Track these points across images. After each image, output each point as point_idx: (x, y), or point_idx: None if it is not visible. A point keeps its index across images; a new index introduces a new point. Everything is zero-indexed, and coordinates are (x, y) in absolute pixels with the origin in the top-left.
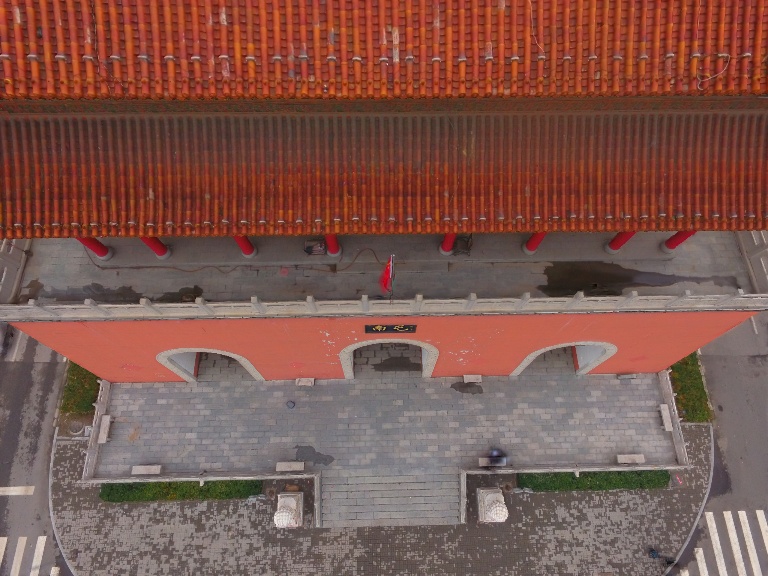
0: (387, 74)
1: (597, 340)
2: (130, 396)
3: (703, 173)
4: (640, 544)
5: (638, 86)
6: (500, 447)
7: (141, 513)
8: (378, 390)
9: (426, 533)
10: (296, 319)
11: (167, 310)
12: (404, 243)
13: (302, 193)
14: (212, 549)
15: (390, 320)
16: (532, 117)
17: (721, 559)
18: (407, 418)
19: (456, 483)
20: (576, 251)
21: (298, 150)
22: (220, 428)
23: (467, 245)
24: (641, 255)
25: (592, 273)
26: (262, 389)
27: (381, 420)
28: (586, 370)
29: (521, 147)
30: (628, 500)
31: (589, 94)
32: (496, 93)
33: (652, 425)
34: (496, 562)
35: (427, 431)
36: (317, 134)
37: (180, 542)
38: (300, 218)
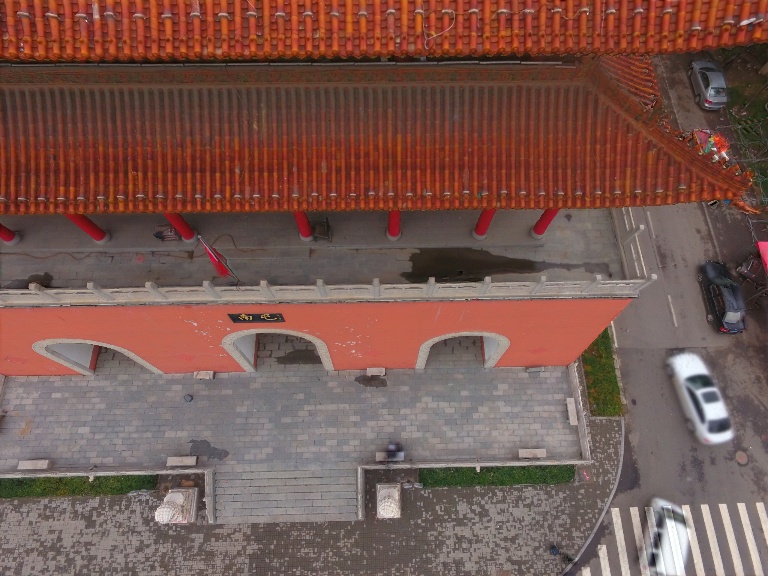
0: (88, 32)
1: (482, 330)
2: (24, 389)
3: (510, 148)
4: (542, 541)
5: (359, 45)
6: (400, 441)
7: (31, 509)
8: (279, 383)
9: (322, 529)
10: (150, 307)
11: (8, 297)
12: (265, 229)
13: (84, 169)
14: (101, 546)
15: (250, 308)
16: (326, 89)
17: (624, 556)
18: (307, 412)
19: (354, 478)
20: (442, 237)
21: (78, 123)
22: (114, 422)
23: (327, 230)
24: (509, 241)
25: (459, 260)
26: (160, 382)
27: (280, 414)
28: (491, 363)
29: (315, 120)
30: (532, 496)
31: (307, 53)
32: (206, 52)
33: (558, 419)
34: (392, 559)
35: (327, 425)
36: (98, 107)
37: (68, 539)
38: (81, 195)
